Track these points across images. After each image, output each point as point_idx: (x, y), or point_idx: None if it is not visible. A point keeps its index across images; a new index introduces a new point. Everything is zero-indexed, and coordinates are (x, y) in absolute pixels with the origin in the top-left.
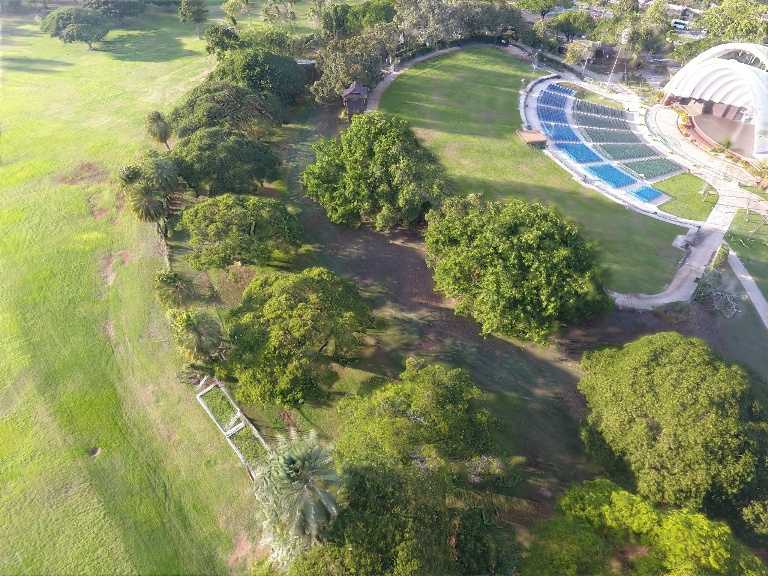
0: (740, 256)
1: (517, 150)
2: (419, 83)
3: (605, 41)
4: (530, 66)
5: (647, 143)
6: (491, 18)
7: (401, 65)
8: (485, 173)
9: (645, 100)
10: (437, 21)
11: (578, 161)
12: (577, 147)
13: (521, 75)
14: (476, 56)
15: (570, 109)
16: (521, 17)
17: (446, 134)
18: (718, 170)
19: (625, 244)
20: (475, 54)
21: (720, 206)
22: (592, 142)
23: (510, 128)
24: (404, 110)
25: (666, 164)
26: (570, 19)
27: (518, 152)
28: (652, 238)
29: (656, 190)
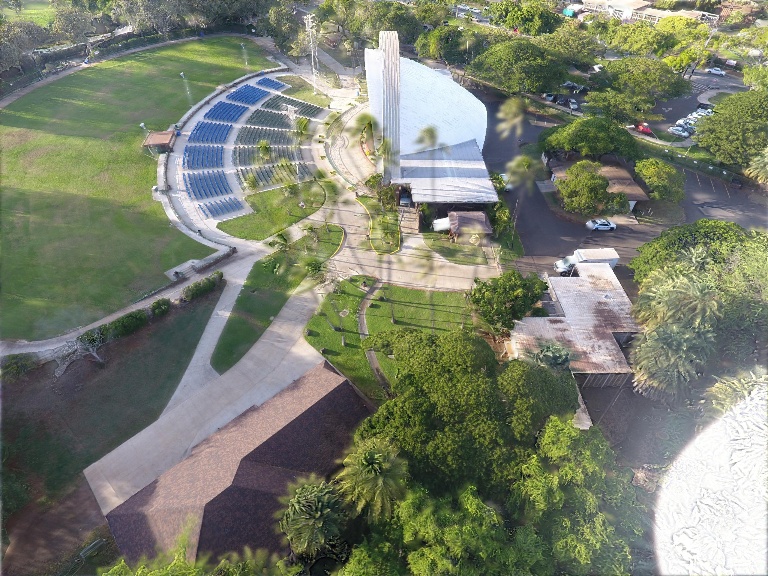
0: (246, 286)
1: (121, 154)
2: (99, 77)
3: (350, 30)
4: (264, 58)
5: (307, 145)
6: (224, 4)
7: (101, 57)
8: (40, 183)
9: (362, 96)
10: (147, 7)
11: (187, 167)
12: (207, 151)
13: (241, 68)
14: (208, 47)
15: (260, 106)
16: (305, 4)
17: (51, 136)
18: (356, 177)
19: (100, 272)
20: (209, 45)
21: (305, 221)
22: (240, 144)
23: (149, 128)
24: (37, 108)
25: (296, 170)
26: (332, 6)
27: (120, 157)
28: (149, 264)
29: (246, 202)
